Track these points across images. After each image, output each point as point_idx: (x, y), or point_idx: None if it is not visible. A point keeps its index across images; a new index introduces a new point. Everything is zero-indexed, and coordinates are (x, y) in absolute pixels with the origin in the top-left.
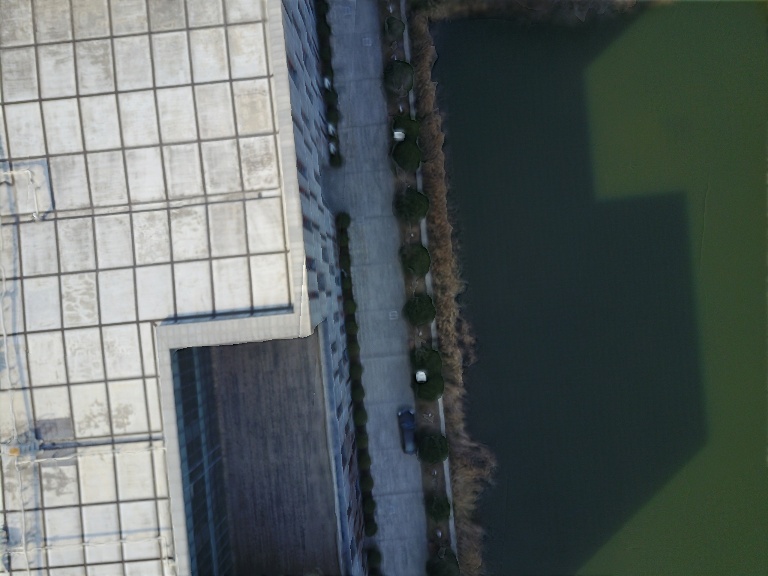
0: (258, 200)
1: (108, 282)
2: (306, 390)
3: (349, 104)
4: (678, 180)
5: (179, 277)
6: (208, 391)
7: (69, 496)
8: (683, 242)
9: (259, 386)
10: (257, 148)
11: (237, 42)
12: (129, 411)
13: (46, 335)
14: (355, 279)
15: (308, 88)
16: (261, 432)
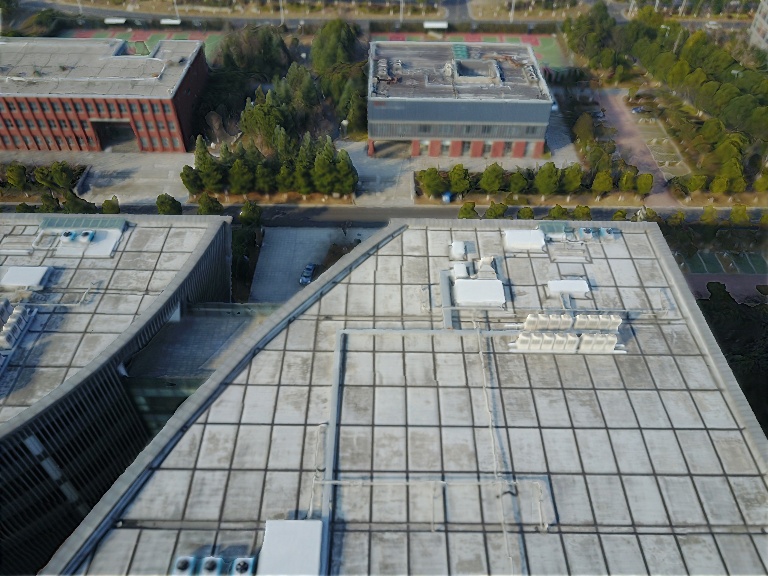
0: (763, 535)
1: None
2: None
3: None
4: None
5: None
6: None
7: None
8: None
9: None
10: (748, 486)
11: (702, 402)
12: None
13: None
14: None
15: None
16: None
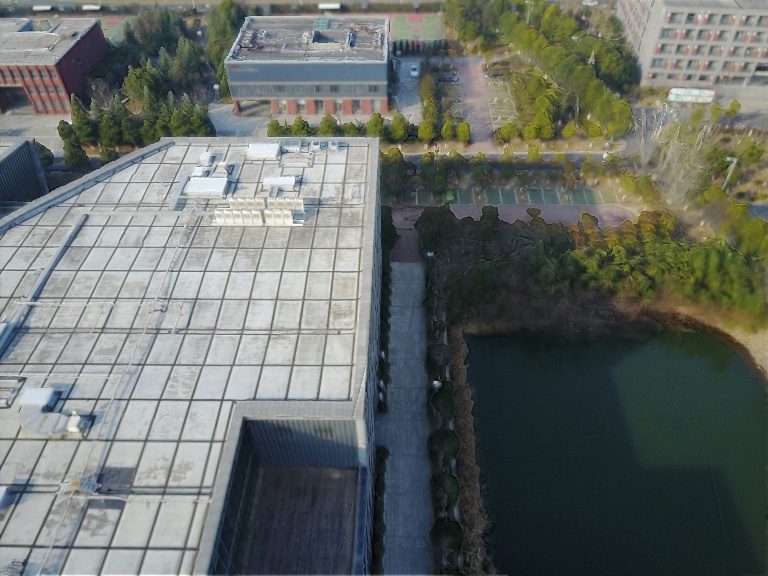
0: (337, 335)
1: (209, 373)
2: (337, 533)
3: (398, 373)
4: (681, 457)
5: (265, 374)
6: (246, 515)
7: (102, 538)
8: (701, 513)
9: (293, 524)
10: (343, 306)
11: (342, 256)
12: (189, 467)
13: (145, 403)
14: (387, 505)
15: (375, 326)
16: (284, 570)
